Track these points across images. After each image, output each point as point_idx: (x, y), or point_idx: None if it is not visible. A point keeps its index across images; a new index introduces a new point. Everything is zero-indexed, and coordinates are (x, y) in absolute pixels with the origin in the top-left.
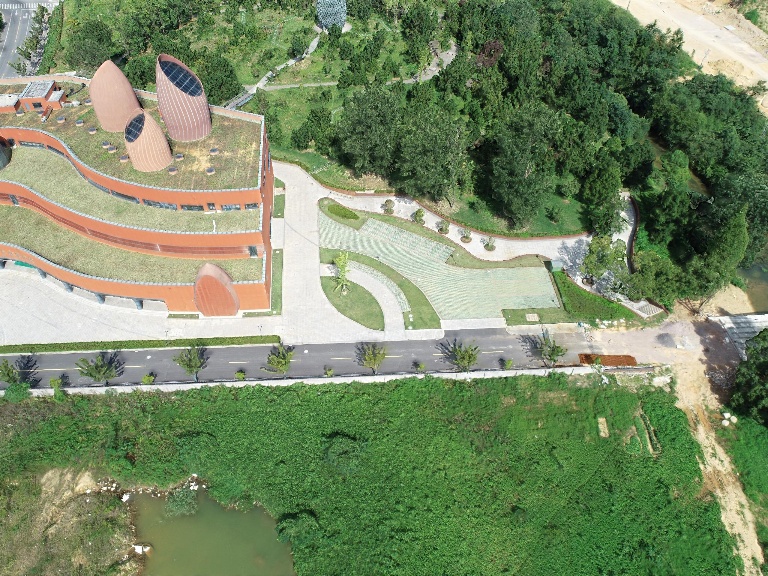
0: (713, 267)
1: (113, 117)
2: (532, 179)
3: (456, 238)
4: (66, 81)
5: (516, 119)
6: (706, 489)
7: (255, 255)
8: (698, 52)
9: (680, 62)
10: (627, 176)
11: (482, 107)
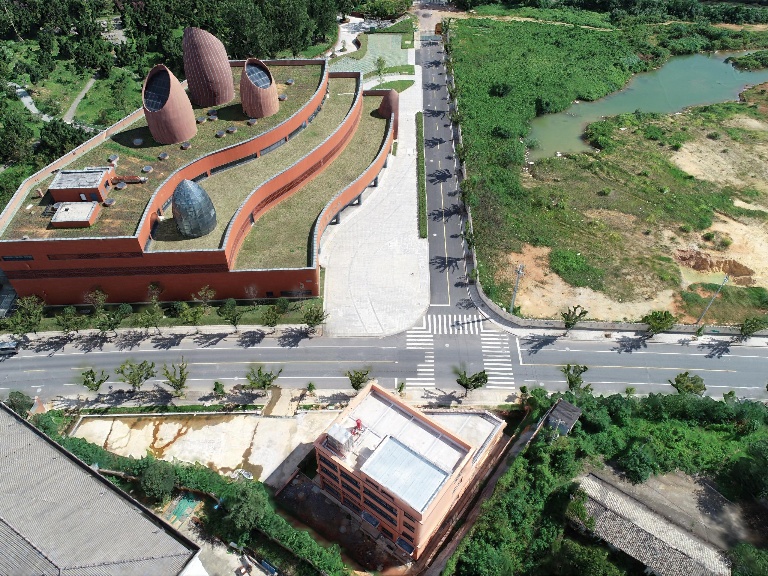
0: None
1: (193, 116)
2: None
3: None
4: (32, 187)
5: None
6: None
7: None
8: None
9: None
10: None
11: None
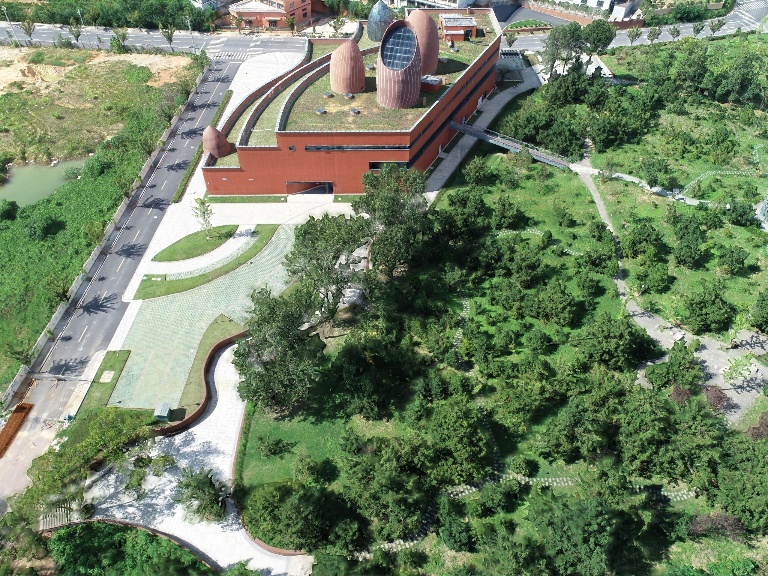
0: None
1: None
2: None
3: None
4: None
5: (295, 292)
6: None
7: None
8: None
9: None
10: None
11: None
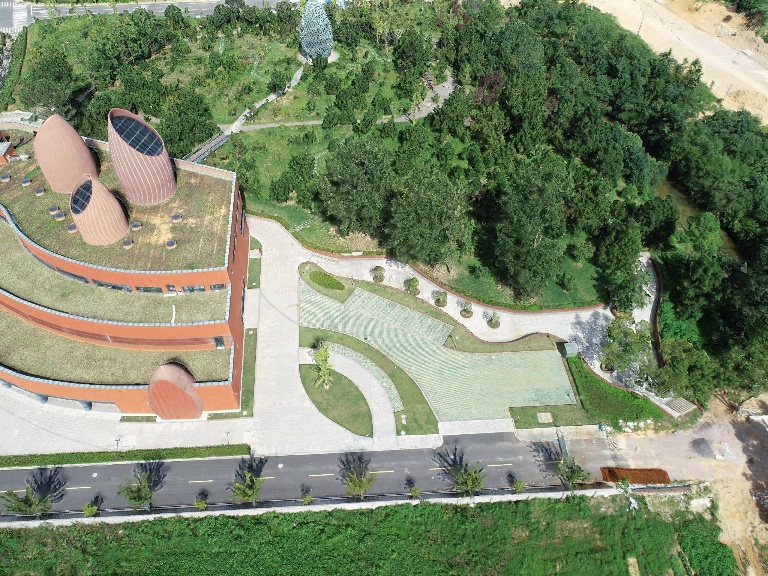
0: (756, 360)
1: (62, 178)
2: (542, 248)
3: (455, 312)
4: (16, 128)
5: (523, 181)
6: None
7: (222, 345)
8: (715, 81)
9: (698, 95)
10: (647, 235)
11: (482, 151)
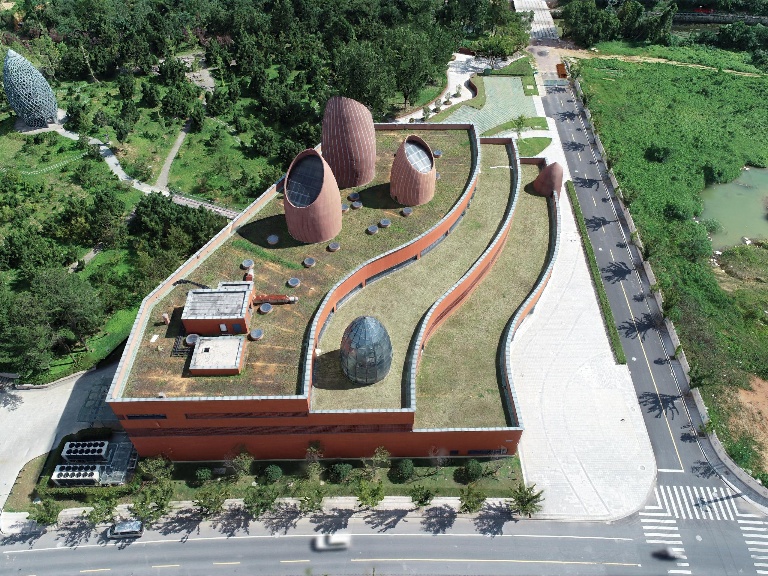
0: None
1: None
2: None
3: (445, 107)
4: (153, 306)
5: None
6: (636, 63)
7: None
8: None
9: None
10: None
11: None
